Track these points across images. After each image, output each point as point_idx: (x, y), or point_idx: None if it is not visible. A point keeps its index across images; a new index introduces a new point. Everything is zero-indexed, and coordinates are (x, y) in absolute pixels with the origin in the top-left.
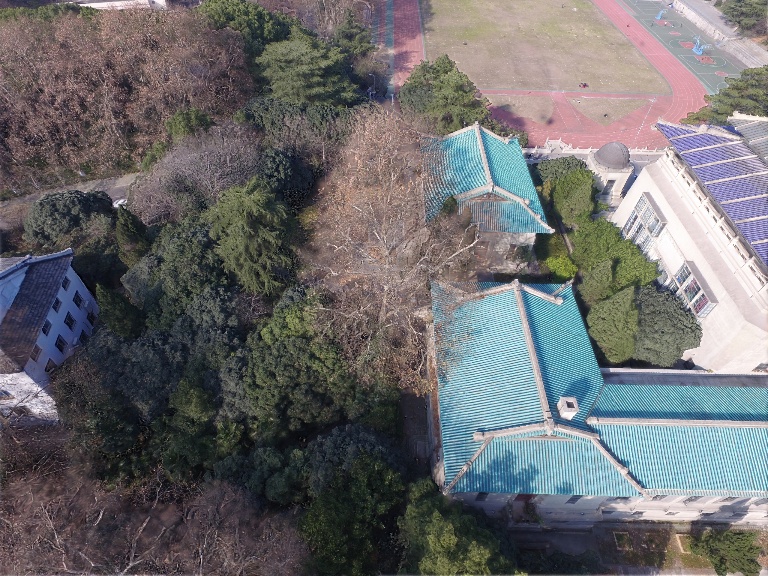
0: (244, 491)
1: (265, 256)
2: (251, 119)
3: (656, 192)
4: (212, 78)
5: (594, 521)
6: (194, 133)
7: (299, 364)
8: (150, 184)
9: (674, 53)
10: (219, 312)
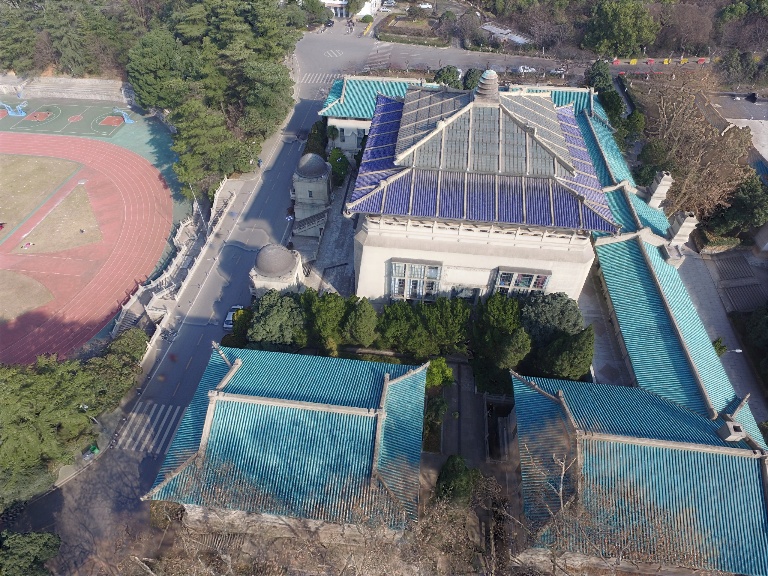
0: None
1: None
2: None
3: (404, 253)
4: None
5: None
6: None
7: None
8: None
9: (3, 129)
10: None
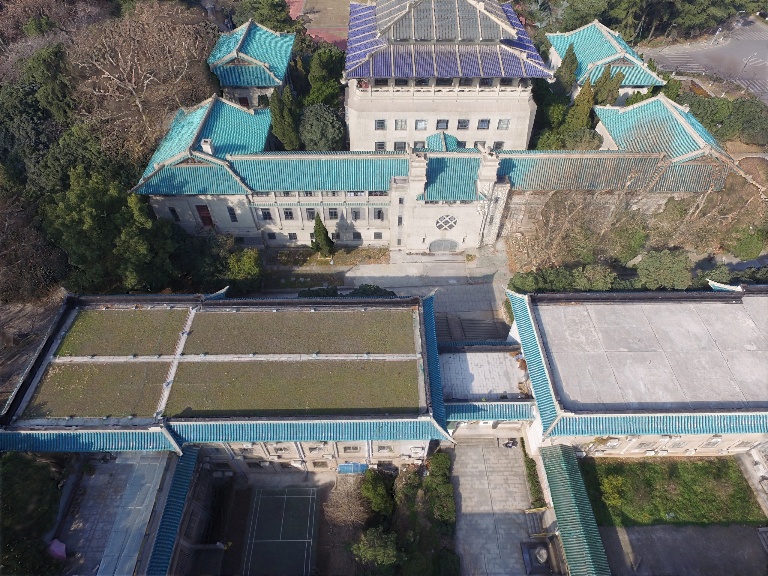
0: (25, 213)
1: (69, 98)
2: (102, 32)
3: None
4: (71, 2)
5: (257, 237)
6: (44, 34)
7: (77, 154)
8: (4, 65)
9: None
10: (31, 129)
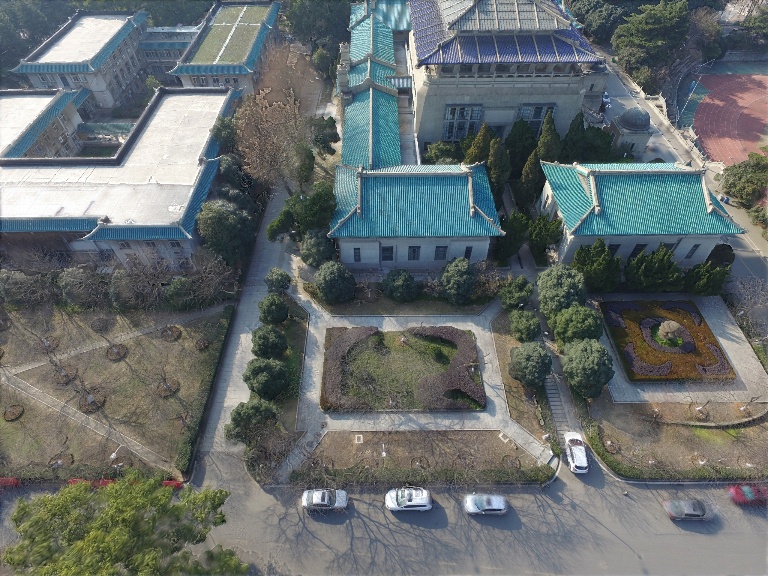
0: None
1: None
2: None
3: None
4: None
5: None
6: None
7: None
8: None
9: None
10: None
